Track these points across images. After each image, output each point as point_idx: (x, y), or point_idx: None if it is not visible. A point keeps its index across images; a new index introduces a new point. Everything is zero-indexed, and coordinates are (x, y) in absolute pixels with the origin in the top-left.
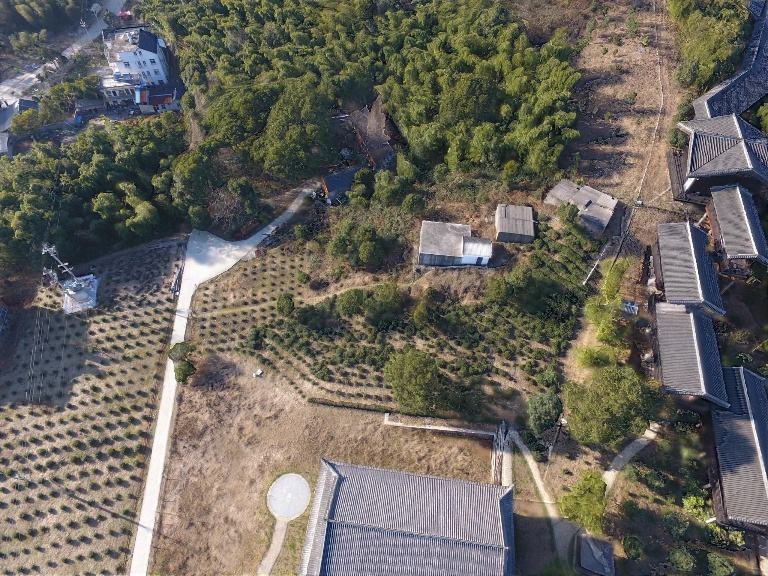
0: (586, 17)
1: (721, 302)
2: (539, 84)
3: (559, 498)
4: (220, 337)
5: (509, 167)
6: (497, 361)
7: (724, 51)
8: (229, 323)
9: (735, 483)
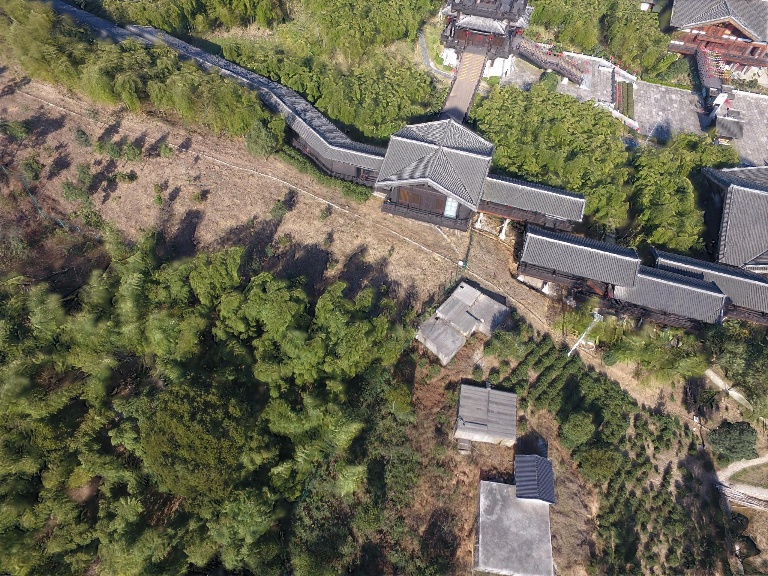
0: (33, 192)
1: (620, 247)
2: (199, 306)
3: (766, 445)
4: None
5: (404, 399)
6: (654, 479)
7: (250, 96)
8: None
9: (765, 304)
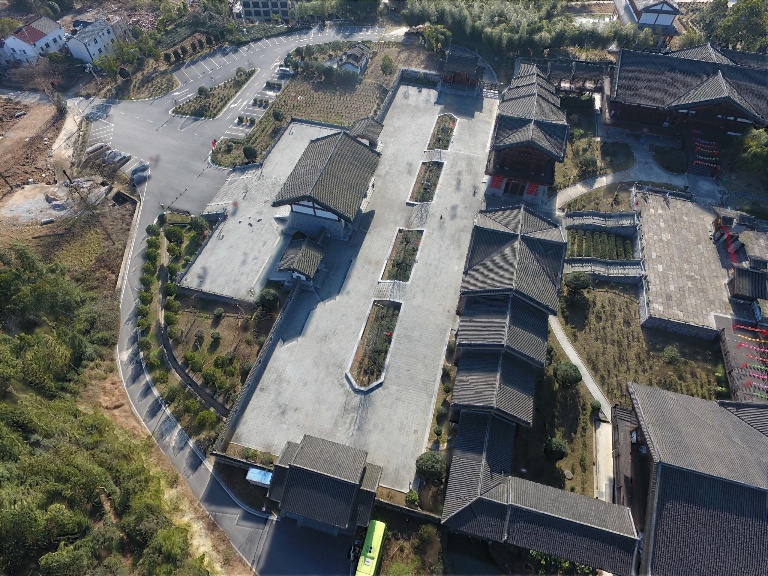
0: None
1: None
2: None
3: None
4: (689, 6)
5: None
6: None
7: None
8: (698, 7)
9: None
